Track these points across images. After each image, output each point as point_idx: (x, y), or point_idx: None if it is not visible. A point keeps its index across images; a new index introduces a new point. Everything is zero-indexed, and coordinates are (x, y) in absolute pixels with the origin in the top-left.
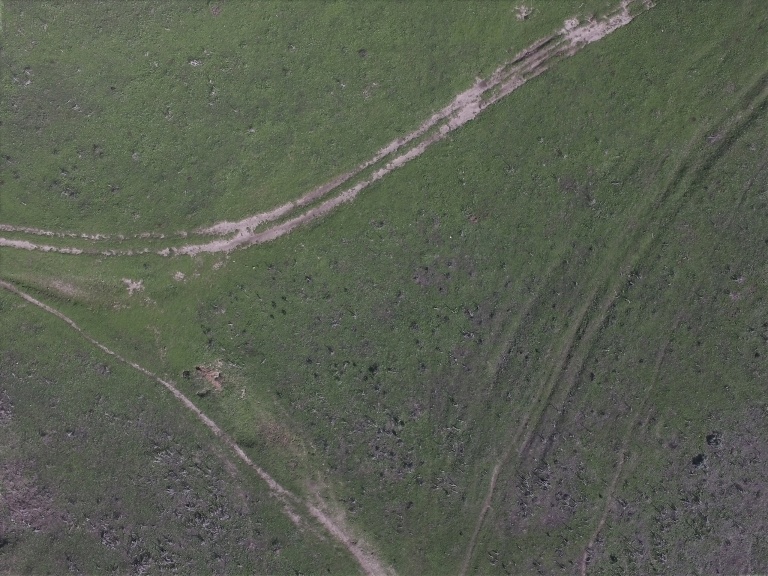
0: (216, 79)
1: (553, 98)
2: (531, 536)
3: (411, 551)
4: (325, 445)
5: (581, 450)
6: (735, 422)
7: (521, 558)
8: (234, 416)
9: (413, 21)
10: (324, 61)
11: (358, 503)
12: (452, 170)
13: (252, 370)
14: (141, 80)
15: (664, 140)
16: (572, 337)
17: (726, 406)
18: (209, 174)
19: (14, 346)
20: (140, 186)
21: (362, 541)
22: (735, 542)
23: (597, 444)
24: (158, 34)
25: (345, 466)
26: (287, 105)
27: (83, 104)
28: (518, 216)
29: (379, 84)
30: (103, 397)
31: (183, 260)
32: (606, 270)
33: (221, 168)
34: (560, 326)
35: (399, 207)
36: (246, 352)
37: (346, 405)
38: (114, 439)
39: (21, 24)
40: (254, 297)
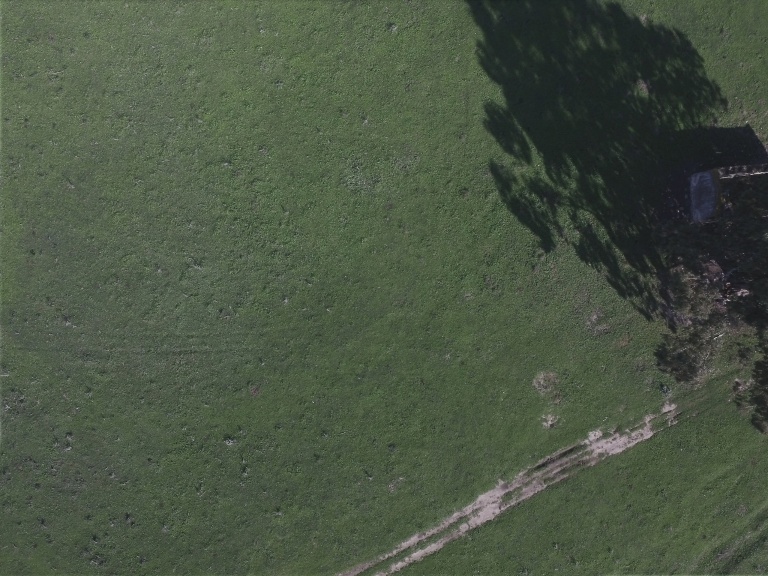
0: (249, 459)
1: (571, 506)
2: None
3: None
4: None
5: None
6: None
7: None
8: None
9: (443, 420)
10: (354, 451)
11: None
12: (468, 568)
13: None
14: (177, 453)
15: (674, 554)
16: None
17: None
18: (234, 552)
19: None
20: (167, 558)
21: None
22: None
23: None
24: (197, 409)
25: None
26: (315, 491)
27: (119, 472)
28: None
29: (405, 479)
30: None
31: None
32: None
33: (246, 548)
34: None
35: None
36: None
37: None
38: None
39: (67, 390)
40: None
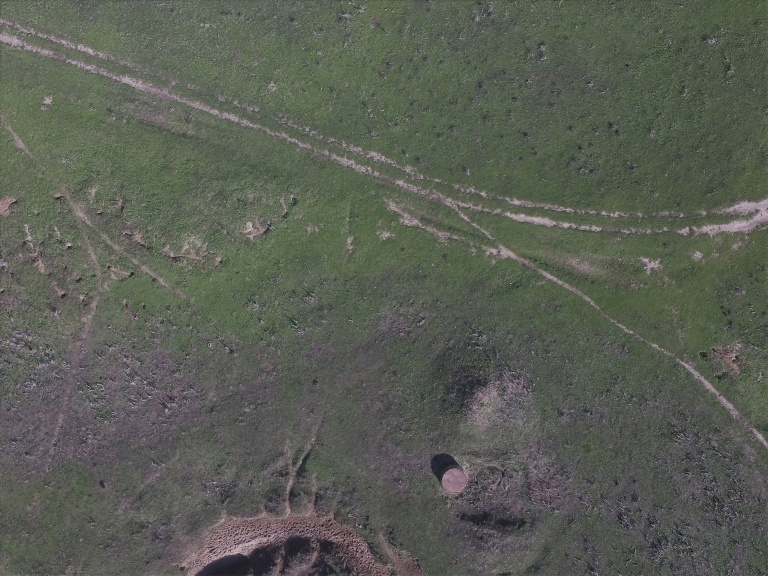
0: (732, 57)
1: None
2: None
3: None
4: None
5: None
6: None
7: None
8: (751, 399)
9: None
10: None
11: None
12: None
13: None
14: (656, 57)
15: None
16: None
17: None
18: (727, 153)
19: (533, 323)
20: (657, 164)
21: None
22: None
23: None
24: (671, 11)
25: None
26: None
27: (597, 81)
28: None
29: None
30: (620, 377)
31: (703, 240)
32: None
33: (740, 147)
34: None
35: None
36: (766, 334)
37: None
38: (631, 420)
39: None
40: None
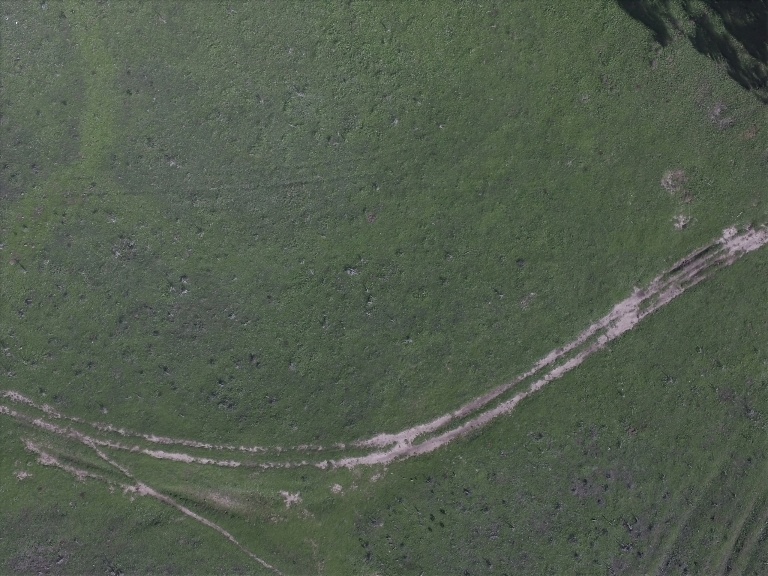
0: (373, 288)
1: (712, 308)
2: None
3: None
4: None
5: None
6: None
7: None
8: None
9: (571, 230)
10: (481, 270)
11: None
12: (610, 381)
13: None
14: (297, 288)
15: None
16: (730, 549)
17: None
18: (366, 385)
19: (172, 560)
20: (297, 396)
21: None
22: None
23: None
24: (314, 241)
25: None
26: (444, 314)
27: (239, 312)
28: (676, 427)
29: (537, 294)
30: None
31: (341, 473)
32: (764, 481)
33: (379, 379)
34: (719, 538)
35: (558, 419)
36: (404, 565)
37: None
38: None
39: (177, 232)
40: (412, 510)
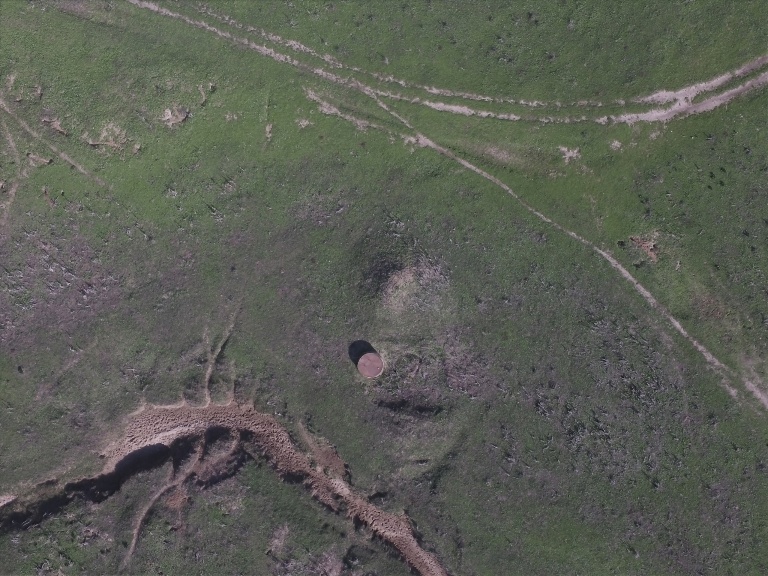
0: None
1: None
2: None
3: None
4: (763, 319)
5: None
6: None
7: None
8: (668, 288)
9: None
10: None
11: None
12: None
13: (689, 241)
14: None
15: None
16: None
17: None
18: (646, 43)
19: (451, 212)
20: (576, 54)
21: None
22: None
23: None
24: None
25: None
26: None
27: None
28: None
29: None
30: (538, 265)
31: (621, 128)
32: None
33: (659, 37)
34: None
35: None
36: (683, 223)
37: None
38: (549, 308)
39: None
40: (692, 167)
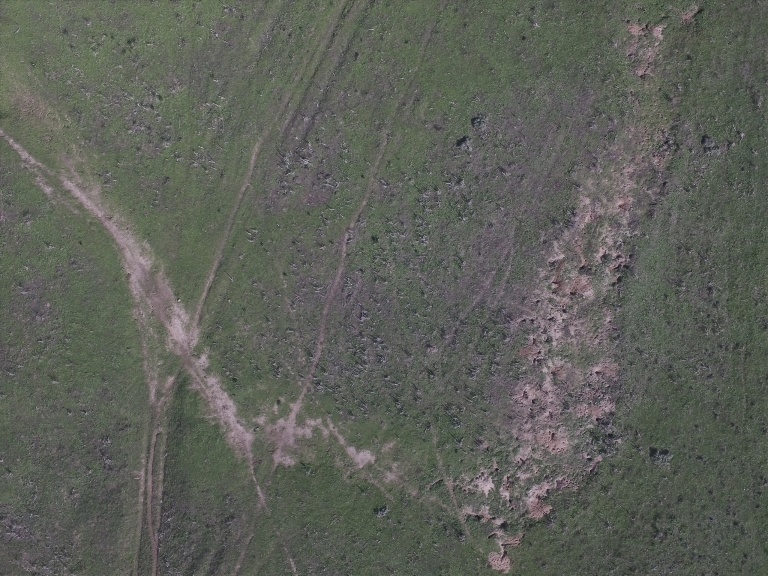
0: None
1: None
2: (291, 215)
3: (167, 227)
4: (80, 117)
5: (344, 130)
6: (500, 105)
7: (280, 236)
8: None
9: None
10: None
11: (113, 176)
12: None
13: (5, 39)
14: None
15: None
16: (337, 17)
17: (492, 89)
18: None
19: None
20: None
21: (117, 217)
22: (498, 226)
23: (360, 124)
24: None
25: (100, 139)
26: None
27: None
28: None
29: None
30: None
31: None
32: None
33: None
34: (325, 5)
35: None
36: None
37: (103, 79)
38: None
39: None
40: None
